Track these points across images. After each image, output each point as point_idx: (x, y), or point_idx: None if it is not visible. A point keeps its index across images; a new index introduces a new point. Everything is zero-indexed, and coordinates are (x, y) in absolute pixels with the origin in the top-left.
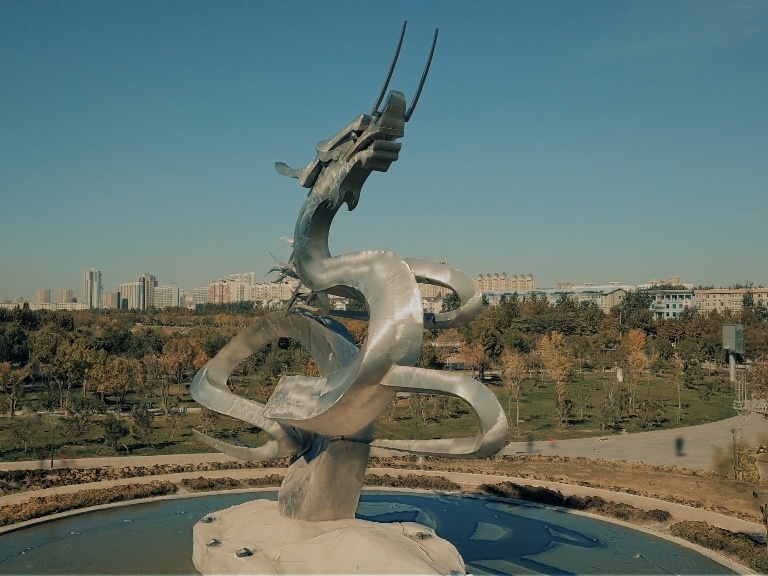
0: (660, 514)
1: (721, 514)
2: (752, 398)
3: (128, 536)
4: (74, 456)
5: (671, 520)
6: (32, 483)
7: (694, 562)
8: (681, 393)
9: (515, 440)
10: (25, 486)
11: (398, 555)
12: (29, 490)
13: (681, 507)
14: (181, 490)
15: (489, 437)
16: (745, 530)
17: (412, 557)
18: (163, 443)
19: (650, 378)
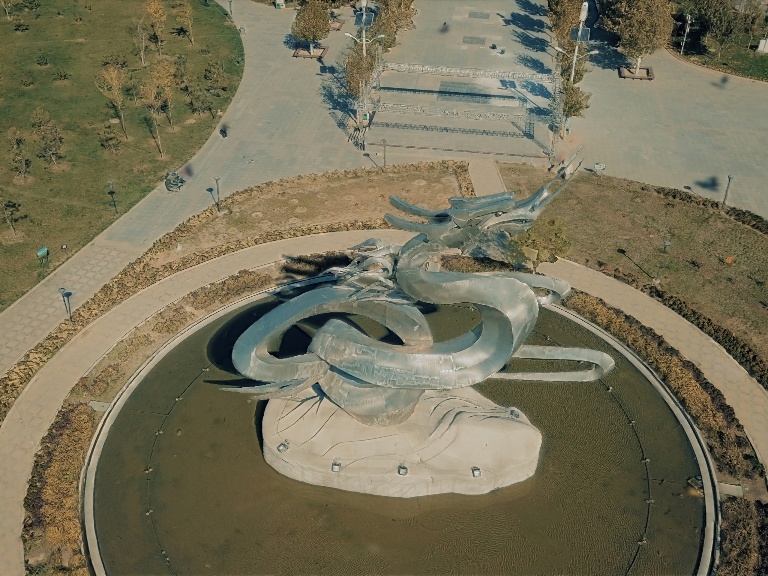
0: None
1: None
2: None
3: (180, 485)
4: None
5: None
6: None
7: None
8: None
9: (173, 167)
10: None
11: (508, 428)
12: None
13: (413, 233)
14: (93, 405)
15: (603, 374)
16: None
17: (513, 425)
18: None
19: None
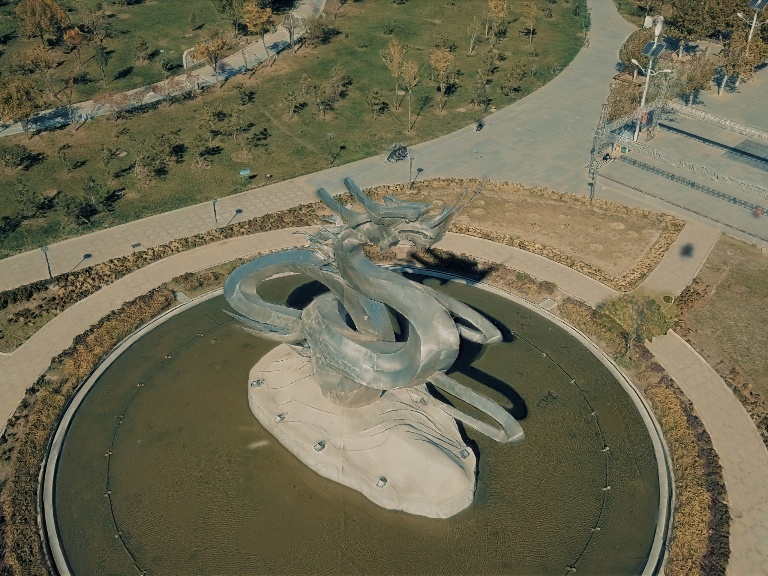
0: (550, 289)
1: (588, 277)
2: (586, 4)
3: (179, 378)
4: (44, 240)
5: (557, 292)
6: (49, 307)
7: (579, 354)
8: (526, 1)
9: (409, 142)
10: (45, 312)
11: (433, 458)
12: (52, 317)
13: (560, 267)
14: (179, 295)
15: (512, 440)
16: (606, 300)
17: (442, 458)
18: (108, 197)
19: (506, 13)
